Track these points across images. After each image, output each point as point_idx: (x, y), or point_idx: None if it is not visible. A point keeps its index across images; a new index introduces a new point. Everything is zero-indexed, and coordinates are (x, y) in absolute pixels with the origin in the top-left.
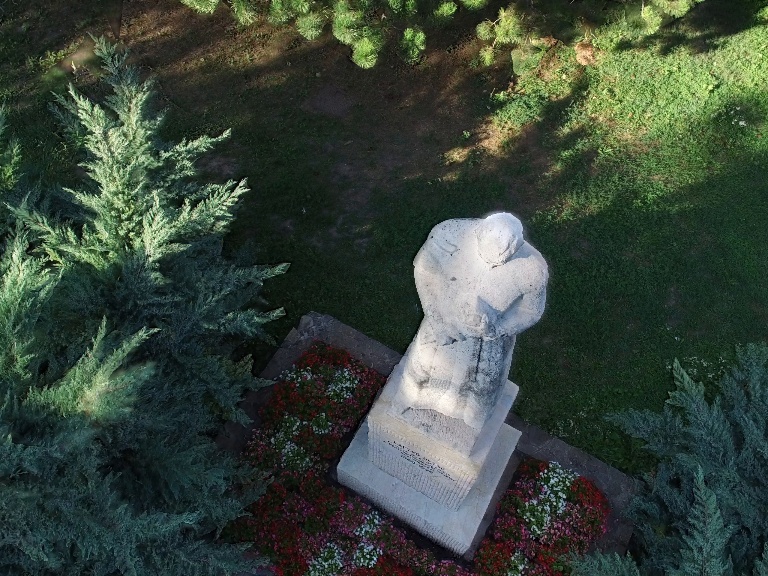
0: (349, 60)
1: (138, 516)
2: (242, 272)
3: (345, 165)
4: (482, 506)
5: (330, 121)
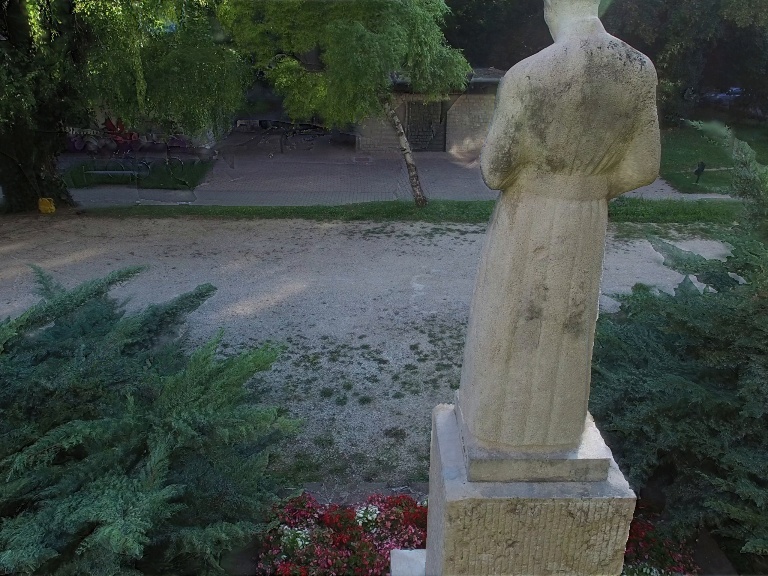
0: None
1: None
2: None
3: None
4: None
5: None
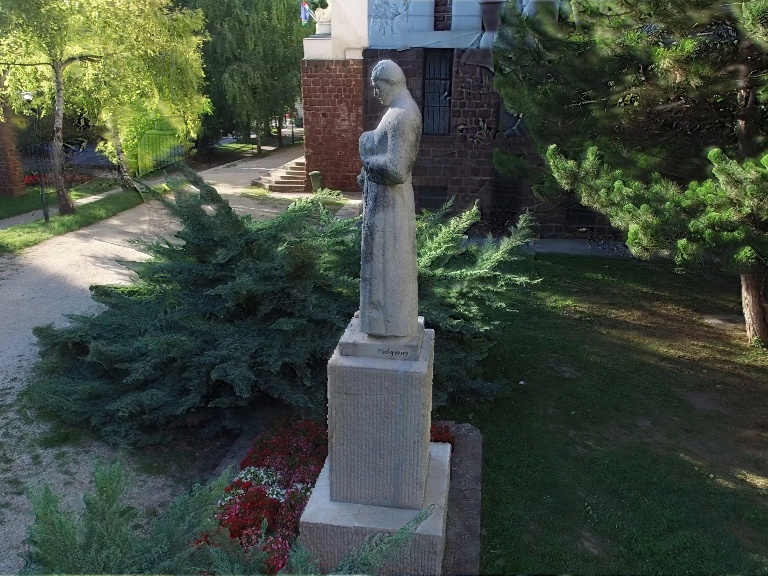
0: (762, 395)
1: (257, 334)
2: (442, 315)
3: (648, 422)
4: (344, 520)
5: (680, 403)
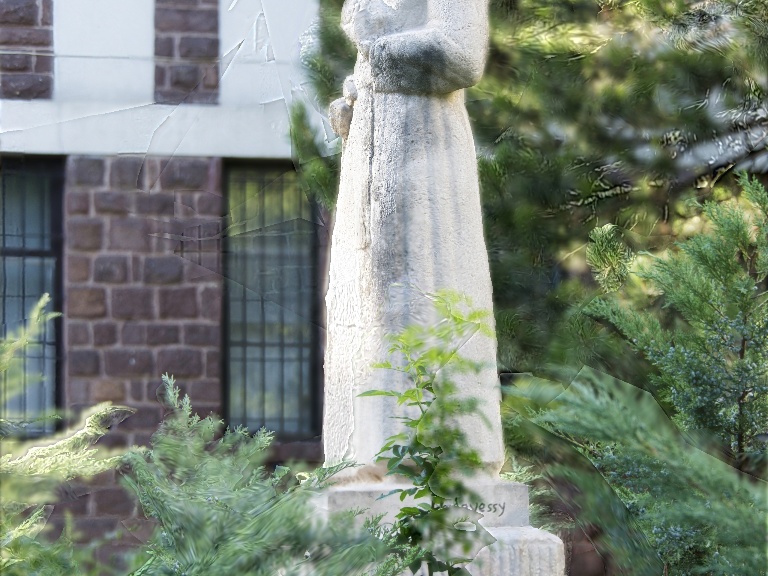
0: None
1: None
2: None
3: None
4: None
5: None
